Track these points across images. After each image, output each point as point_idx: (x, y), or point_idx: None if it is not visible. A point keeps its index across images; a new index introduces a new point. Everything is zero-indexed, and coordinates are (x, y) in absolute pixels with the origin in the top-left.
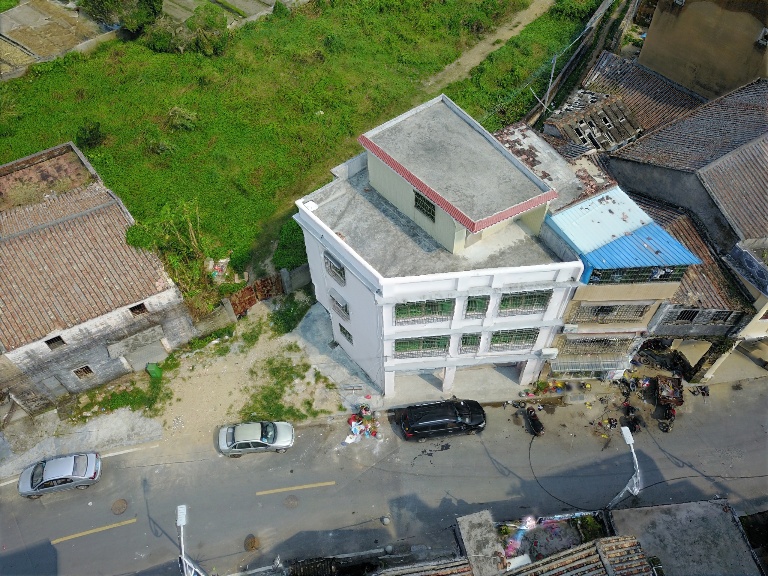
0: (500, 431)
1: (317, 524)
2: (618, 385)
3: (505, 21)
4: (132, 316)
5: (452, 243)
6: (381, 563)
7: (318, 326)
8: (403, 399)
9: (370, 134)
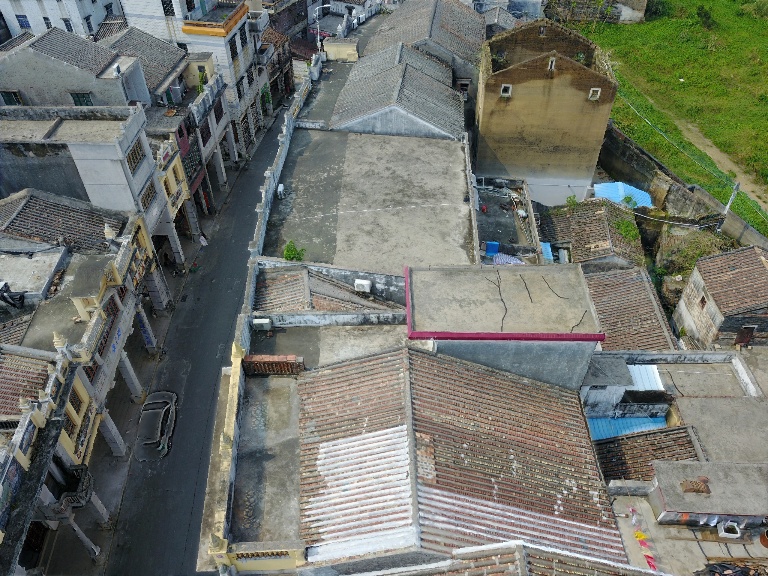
0: None
1: None
2: None
3: None
4: None
5: None
6: None
7: None
8: None
9: None
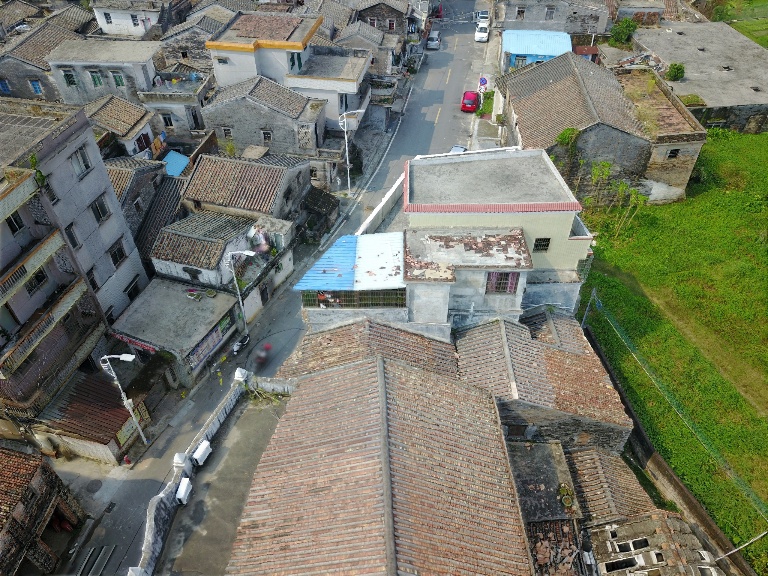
0: None
1: None
2: None
3: None
4: None
5: None
6: (316, 242)
7: None
8: None
9: None
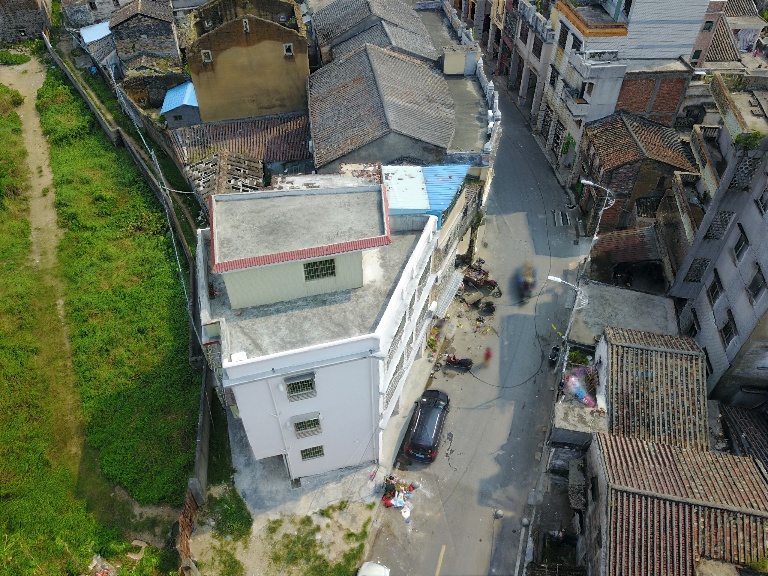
0: (454, 391)
1: None
2: (454, 300)
3: (24, 174)
4: None
5: (361, 277)
6: None
7: (264, 489)
8: (389, 448)
9: None
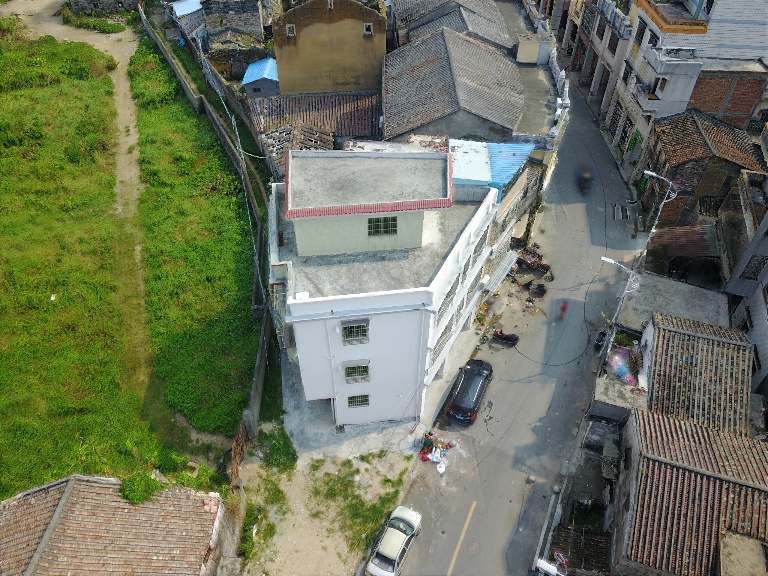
0: (498, 363)
1: (506, 536)
2: (505, 280)
3: (114, 132)
4: (205, 570)
5: (421, 237)
6: None
7: (310, 431)
8: (430, 408)
9: (290, 207)
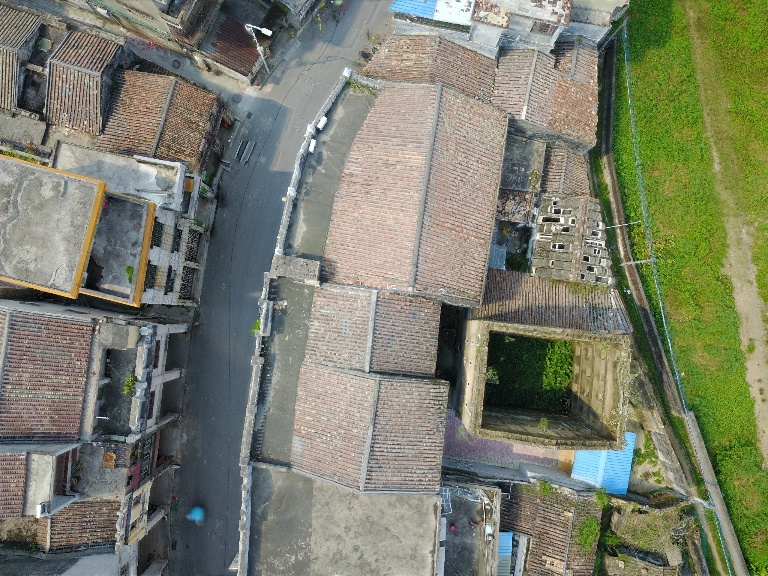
0: None
1: None
2: None
3: None
4: None
5: None
6: None
7: None
8: None
9: None
